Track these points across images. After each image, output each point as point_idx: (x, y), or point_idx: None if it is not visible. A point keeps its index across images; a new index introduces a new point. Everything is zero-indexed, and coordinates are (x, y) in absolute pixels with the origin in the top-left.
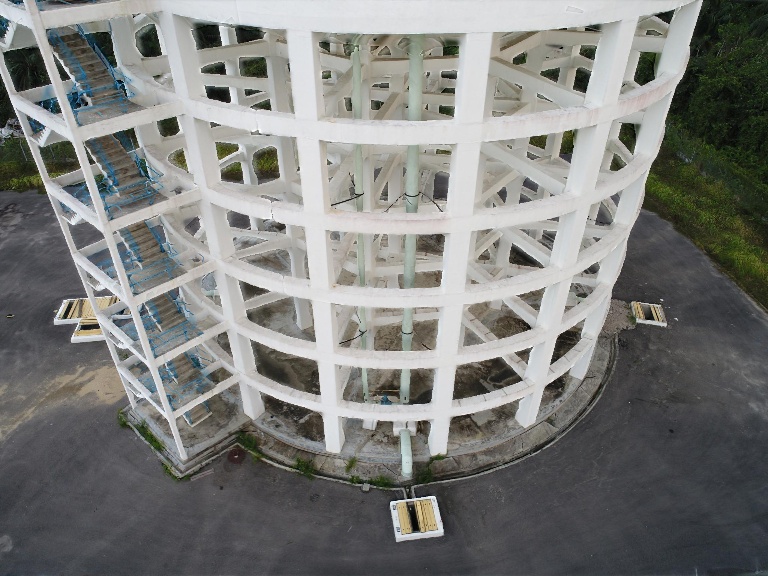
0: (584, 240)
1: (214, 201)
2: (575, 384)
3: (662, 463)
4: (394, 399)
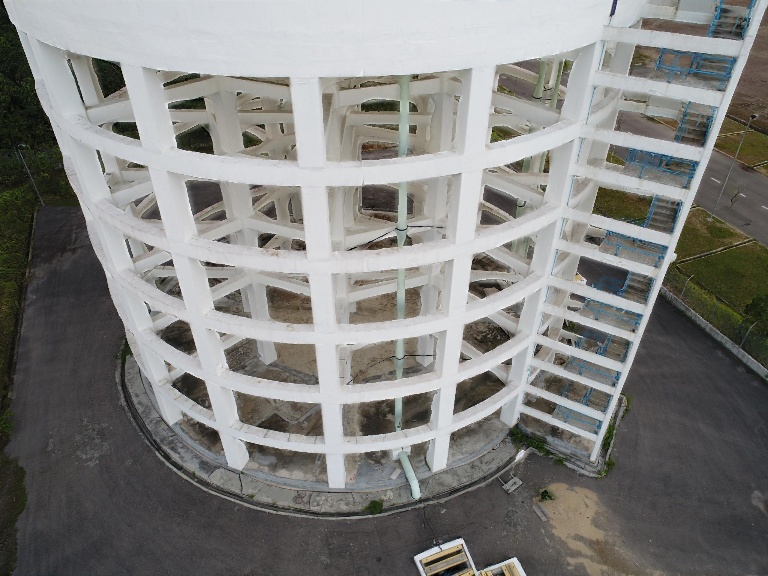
0: None
1: None
2: None
3: None
4: (489, 289)
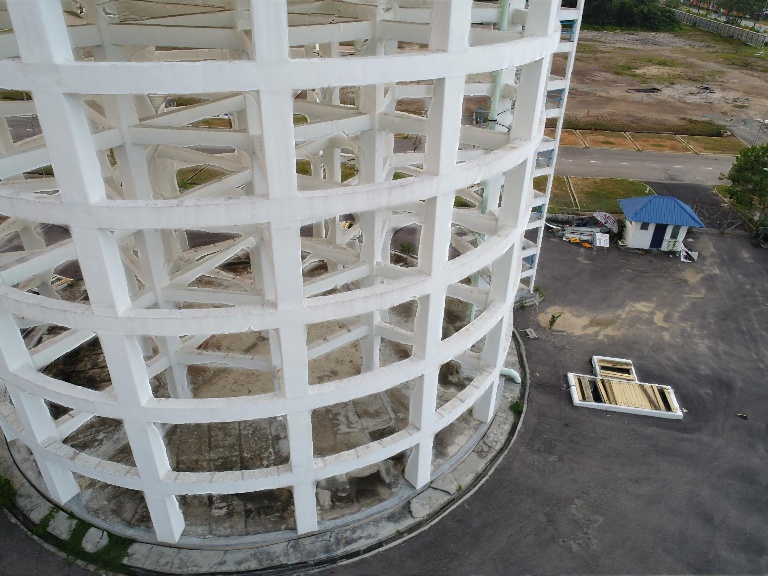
0: (53, 267)
1: None
2: None
3: None
4: None
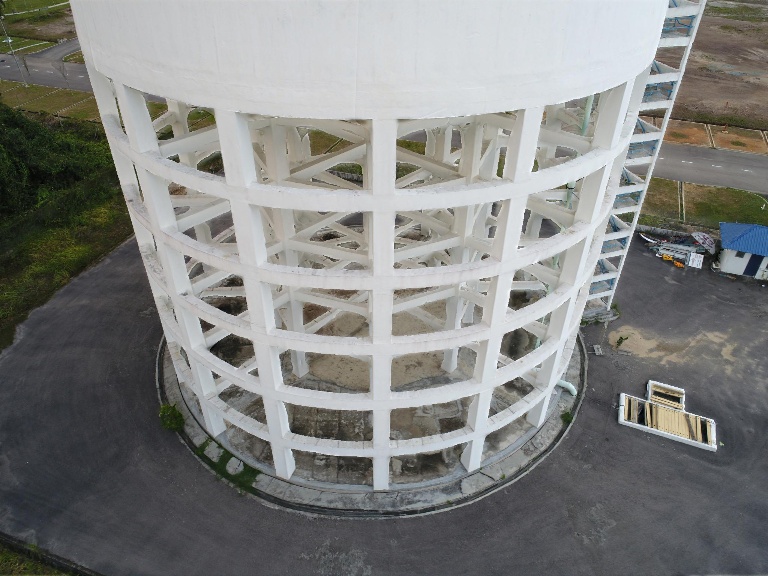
0: None
1: None
2: (320, 232)
3: None
4: None
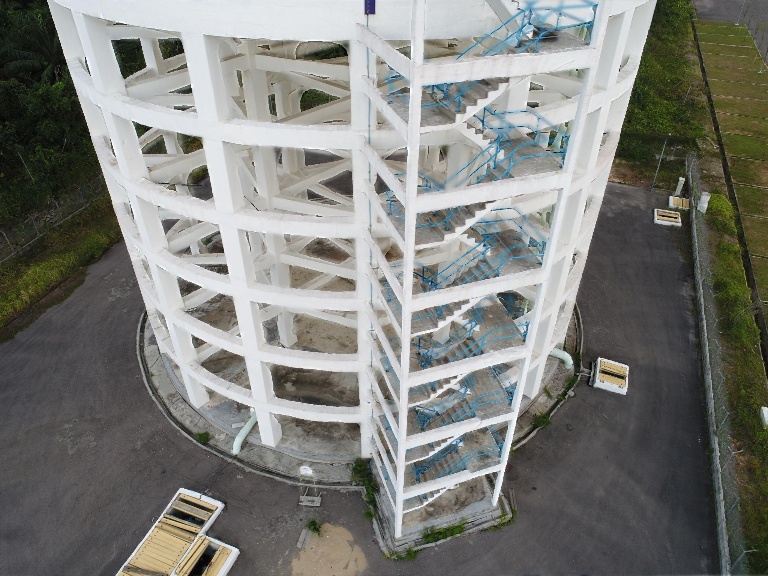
0: None
1: (515, 215)
2: None
3: (603, 257)
4: None
